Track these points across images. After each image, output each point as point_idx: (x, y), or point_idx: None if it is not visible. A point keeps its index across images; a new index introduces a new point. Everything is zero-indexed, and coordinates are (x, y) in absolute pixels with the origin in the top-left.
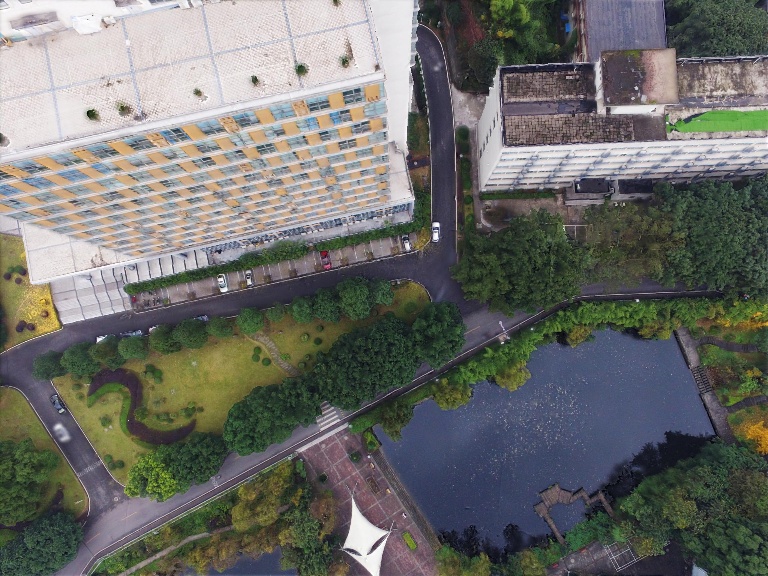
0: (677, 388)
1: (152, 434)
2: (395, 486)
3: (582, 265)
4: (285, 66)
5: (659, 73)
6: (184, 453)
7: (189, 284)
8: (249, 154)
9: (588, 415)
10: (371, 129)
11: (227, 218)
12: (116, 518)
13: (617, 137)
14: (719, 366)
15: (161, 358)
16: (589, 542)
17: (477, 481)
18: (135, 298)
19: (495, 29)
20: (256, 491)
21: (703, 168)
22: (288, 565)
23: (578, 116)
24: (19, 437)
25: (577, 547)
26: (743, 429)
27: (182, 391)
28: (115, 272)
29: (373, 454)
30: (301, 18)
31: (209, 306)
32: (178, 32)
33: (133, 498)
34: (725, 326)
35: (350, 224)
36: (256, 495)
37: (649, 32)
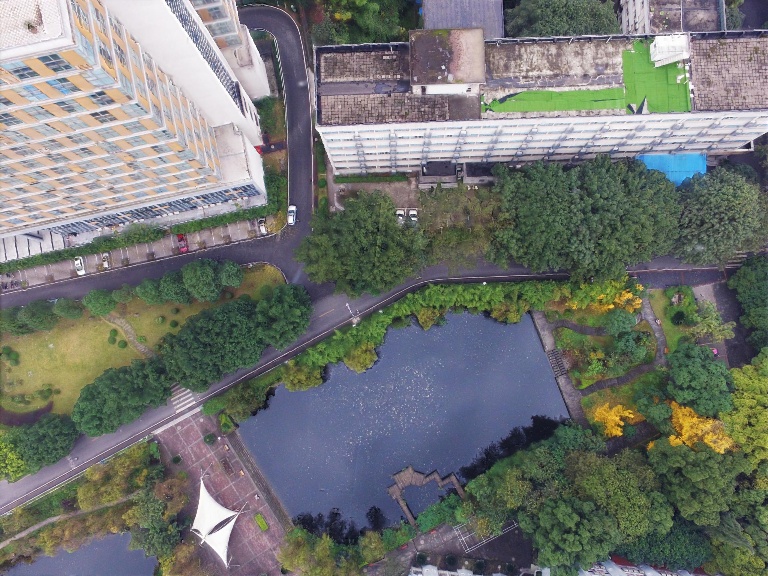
0: (532, 371)
1: (9, 416)
2: (250, 468)
3: (414, 246)
4: None
5: (466, 52)
6: (31, 434)
7: (47, 267)
8: None
9: (443, 398)
10: (115, 100)
11: (39, 196)
12: None
13: (432, 117)
14: (573, 349)
15: (18, 340)
16: (439, 523)
17: (332, 463)
18: None
19: (336, 12)
20: (100, 471)
21: (543, 150)
22: (135, 545)
23: (394, 96)
24: None
25: (427, 528)
26: None
27: (39, 373)
28: None
29: (228, 436)
30: None
31: (67, 289)
32: None
33: None
34: None
35: (205, 207)
36: (101, 475)
37: (486, 15)
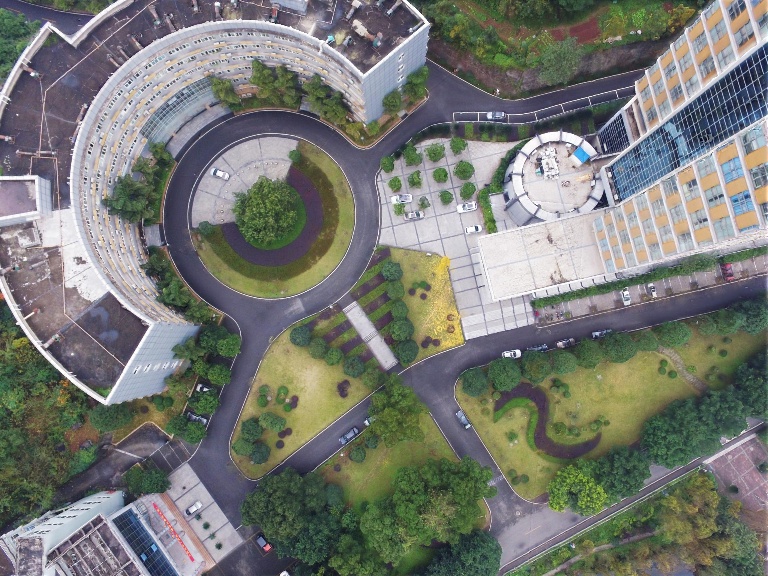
0: None
1: (558, 448)
2: None
3: None
4: None
5: None
6: (619, 467)
7: (590, 298)
8: None
9: None
10: None
11: None
12: (520, 532)
13: None
14: None
15: None
16: None
17: None
18: (538, 312)
19: None
20: (698, 504)
21: None
22: None
23: None
24: None
25: None
26: None
27: (588, 405)
28: None
29: None
30: None
31: (612, 319)
32: None
33: (536, 512)
34: None
35: None
36: None
37: None
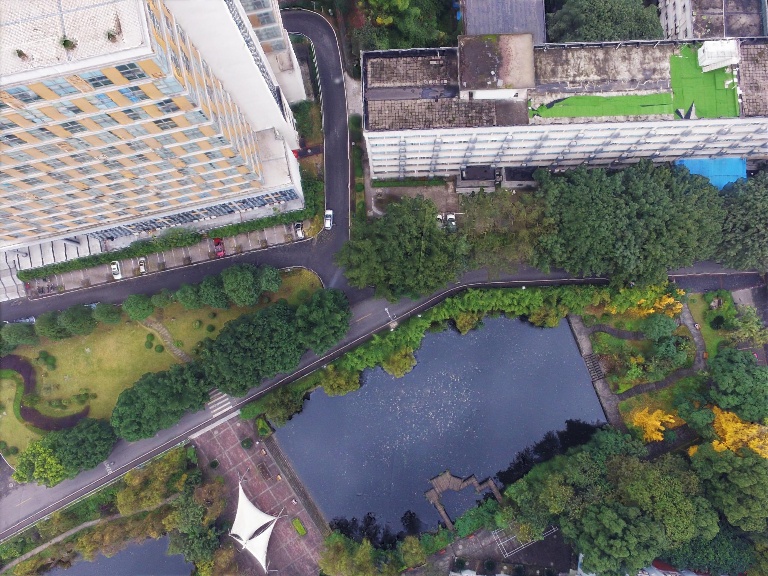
0: (569, 376)
1: (46, 420)
2: (287, 472)
3: (457, 251)
4: (54, 41)
5: (516, 58)
6: (70, 438)
7: (83, 271)
8: (57, 132)
9: (480, 402)
10: (180, 108)
11: (87, 202)
12: (11, 504)
13: (479, 122)
14: (610, 354)
15: (55, 345)
16: (477, 528)
17: (369, 468)
18: (29, 285)
19: (376, 16)
20: (140, 476)
21: (584, 155)
22: (174, 550)
23: (441, 101)
24: None
25: (465, 533)
26: (633, 416)
27: (75, 378)
28: (8, 259)
29: (265, 441)
30: None
31: (103, 293)
32: None
33: (28, 484)
34: (612, 313)
35: (242, 211)
36: (140, 480)
37: (528, 19)
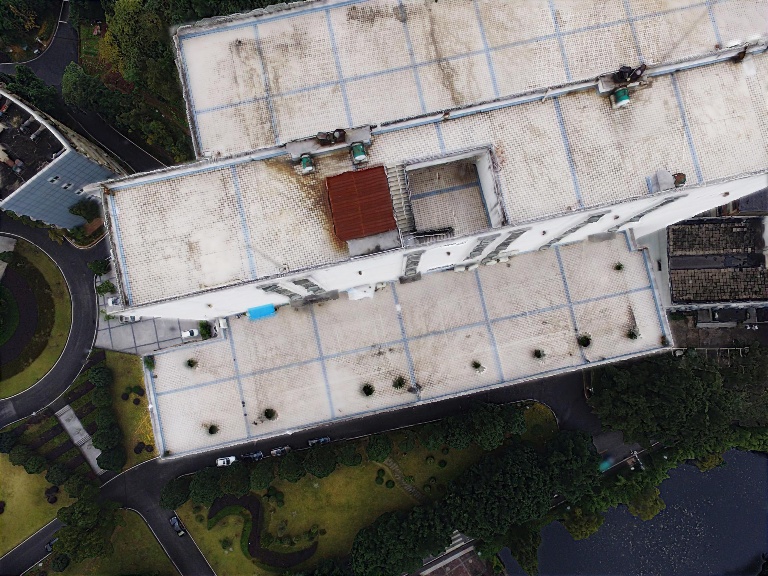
0: None
1: (273, 557)
2: None
3: (732, 407)
4: (565, 335)
5: None
6: None
7: None
8: None
9: (714, 537)
10: None
11: None
12: None
13: None
14: None
15: (282, 480)
16: None
17: None
18: None
19: None
20: None
21: None
22: None
23: (746, 271)
24: (139, 561)
25: None
26: None
27: (304, 513)
28: None
29: None
30: (580, 283)
31: (331, 427)
32: (451, 296)
33: None
34: None
35: None
36: None
37: None
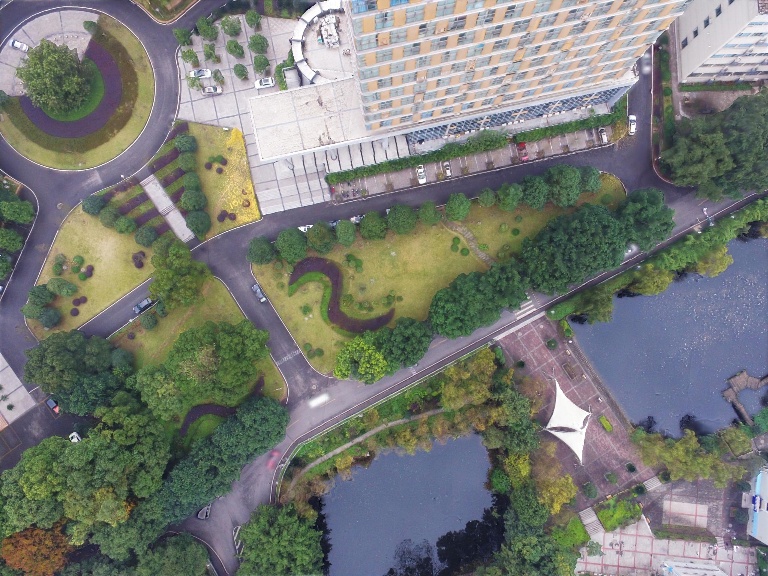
0: None
1: (352, 323)
2: (589, 373)
3: None
4: None
5: None
6: (397, 335)
7: (387, 176)
8: None
9: None
10: None
11: (490, 81)
12: (315, 405)
13: None
14: None
15: (361, 248)
16: None
17: (667, 368)
18: (334, 189)
19: None
20: (471, 370)
21: None
22: (496, 443)
23: None
24: None
25: (767, 429)
26: None
27: (381, 281)
28: (317, 162)
29: (568, 342)
30: None
31: (407, 197)
32: None
33: (331, 386)
34: None
35: (549, 115)
36: None
37: None
